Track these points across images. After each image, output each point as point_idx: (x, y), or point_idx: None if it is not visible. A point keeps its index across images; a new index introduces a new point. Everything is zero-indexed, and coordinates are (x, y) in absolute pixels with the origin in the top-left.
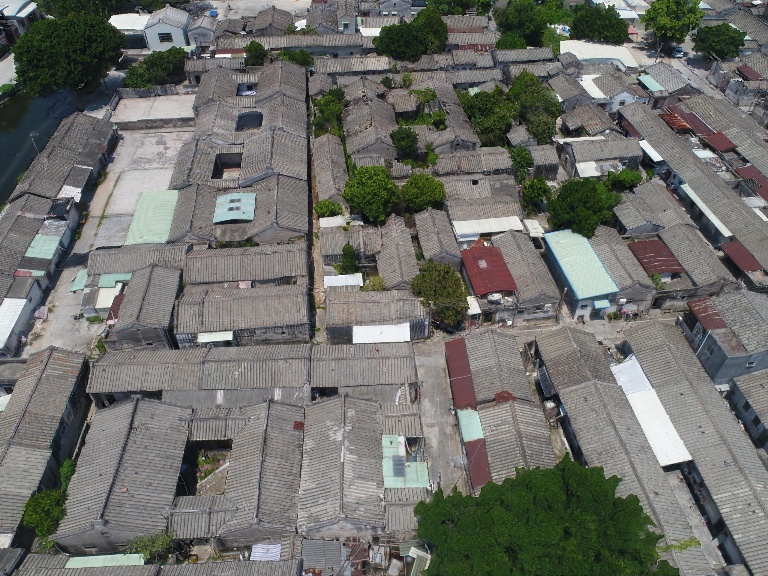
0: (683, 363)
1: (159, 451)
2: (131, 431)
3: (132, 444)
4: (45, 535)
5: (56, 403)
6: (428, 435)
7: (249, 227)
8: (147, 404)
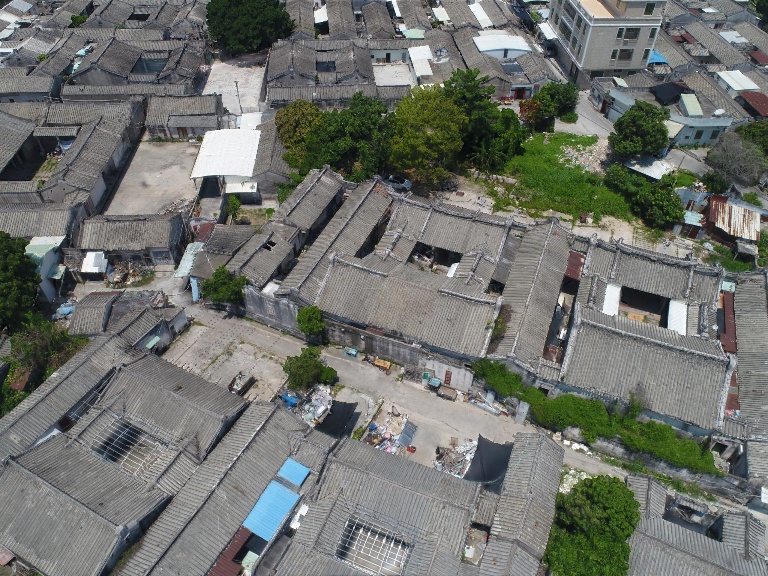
0: (341, 1)
1: (121, 11)
2: (111, 4)
3: (111, 7)
4: (79, 24)
5: (81, 7)
6: None
7: None
8: (117, 1)
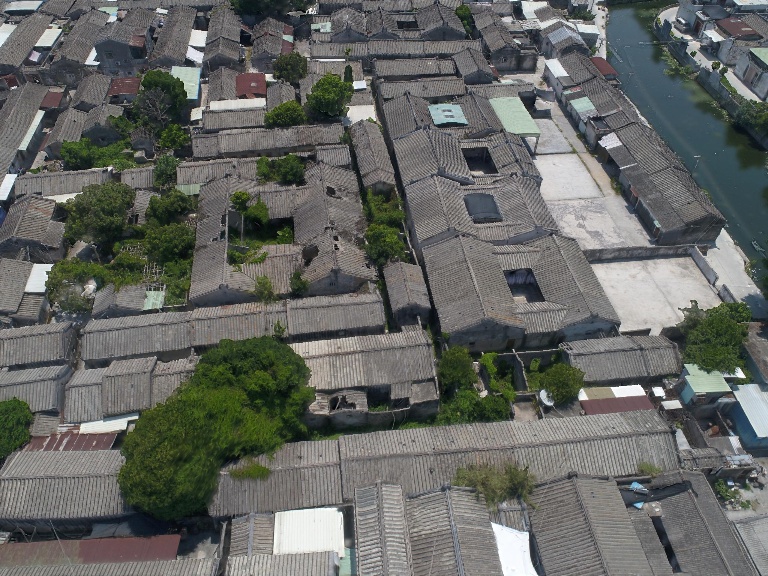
0: None
1: None
2: None
3: None
4: None
5: None
6: (308, 55)
7: (430, 104)
8: None
